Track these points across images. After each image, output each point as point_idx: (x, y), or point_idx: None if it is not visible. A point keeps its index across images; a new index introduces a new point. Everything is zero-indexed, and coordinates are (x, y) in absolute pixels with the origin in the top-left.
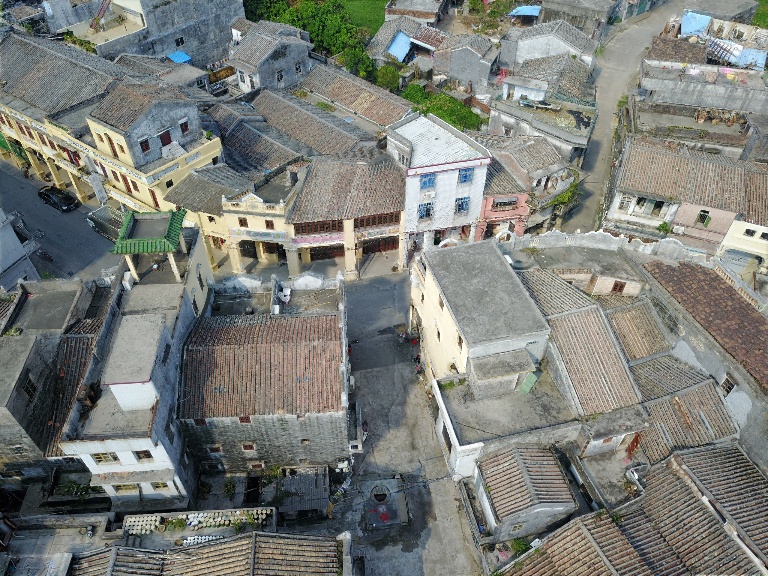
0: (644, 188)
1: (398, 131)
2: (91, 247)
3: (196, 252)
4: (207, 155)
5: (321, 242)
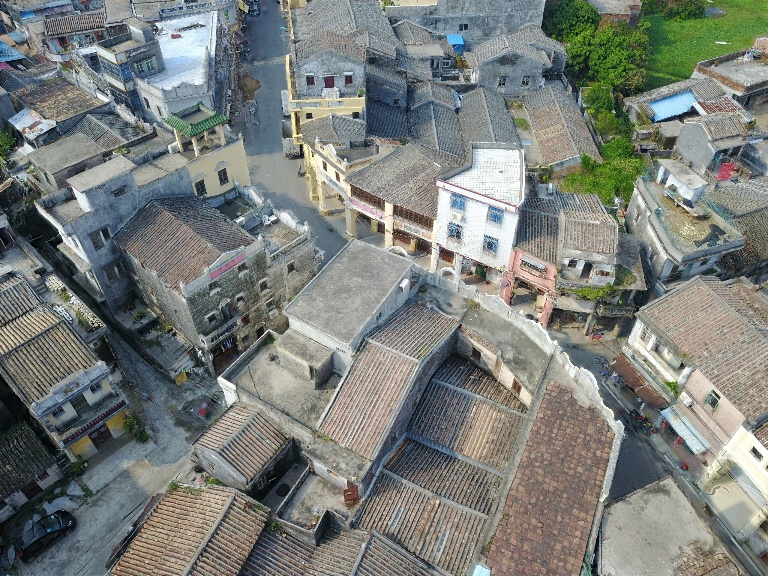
0: (666, 328)
1: (480, 151)
2: (271, 145)
3: (225, 152)
4: (349, 107)
5: (369, 212)
